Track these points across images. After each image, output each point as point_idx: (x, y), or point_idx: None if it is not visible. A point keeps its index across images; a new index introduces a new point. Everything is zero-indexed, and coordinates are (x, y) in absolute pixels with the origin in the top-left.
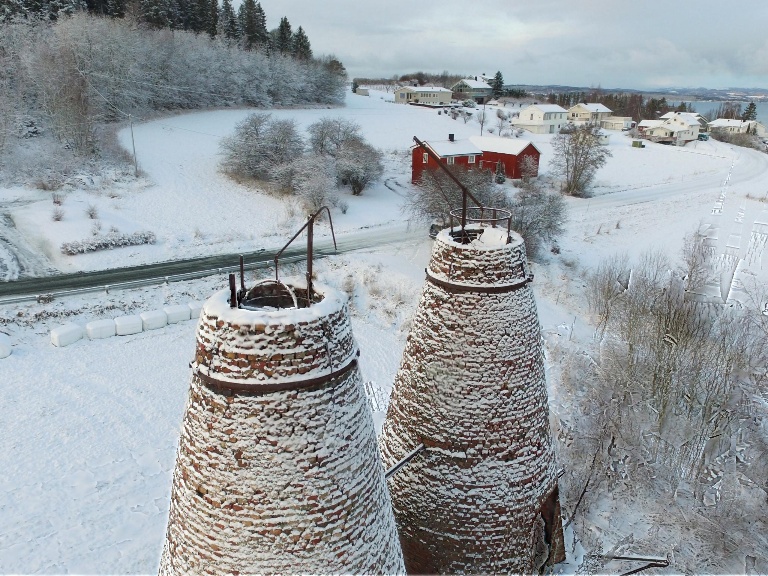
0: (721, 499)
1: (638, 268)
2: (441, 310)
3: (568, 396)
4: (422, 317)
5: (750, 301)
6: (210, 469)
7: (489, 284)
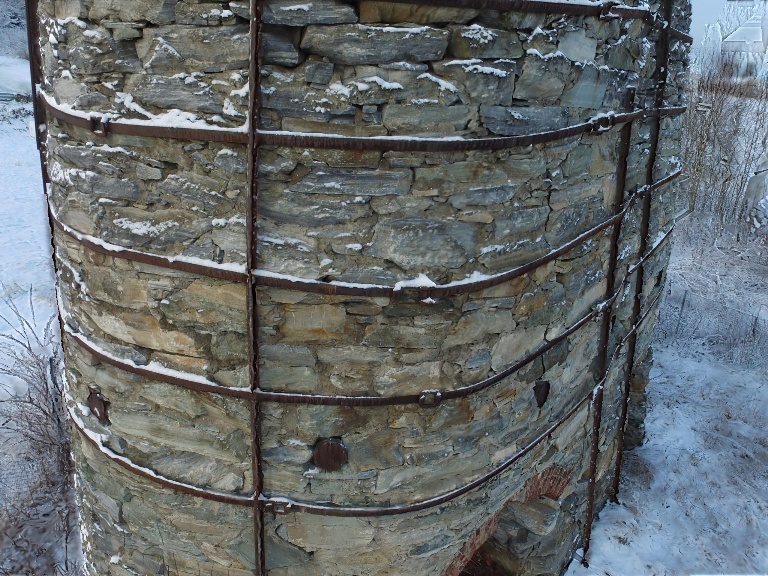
0: (767, 239)
1: None
2: None
3: None
4: None
5: None
6: None
7: None
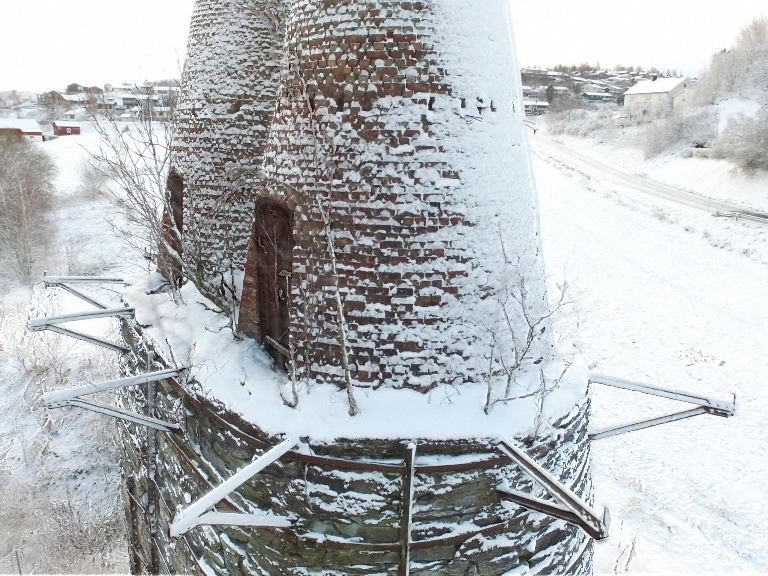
0: None
1: None
2: None
3: None
4: None
5: None
6: None
7: None
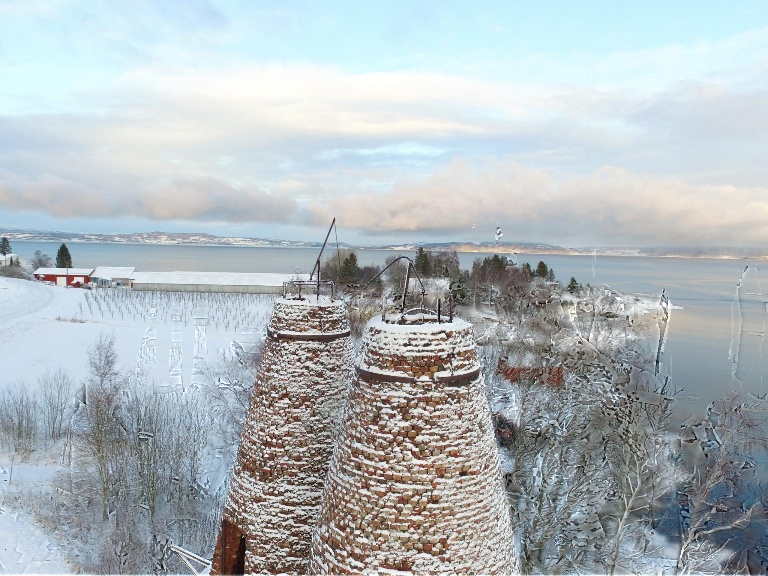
0: None
1: (95, 380)
2: (321, 358)
3: (59, 534)
4: (302, 371)
5: (207, 380)
6: (469, 447)
7: (345, 330)
